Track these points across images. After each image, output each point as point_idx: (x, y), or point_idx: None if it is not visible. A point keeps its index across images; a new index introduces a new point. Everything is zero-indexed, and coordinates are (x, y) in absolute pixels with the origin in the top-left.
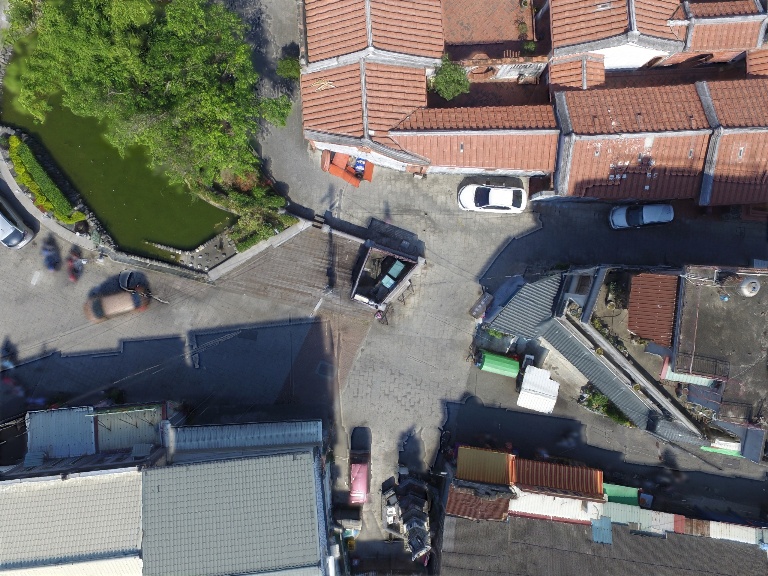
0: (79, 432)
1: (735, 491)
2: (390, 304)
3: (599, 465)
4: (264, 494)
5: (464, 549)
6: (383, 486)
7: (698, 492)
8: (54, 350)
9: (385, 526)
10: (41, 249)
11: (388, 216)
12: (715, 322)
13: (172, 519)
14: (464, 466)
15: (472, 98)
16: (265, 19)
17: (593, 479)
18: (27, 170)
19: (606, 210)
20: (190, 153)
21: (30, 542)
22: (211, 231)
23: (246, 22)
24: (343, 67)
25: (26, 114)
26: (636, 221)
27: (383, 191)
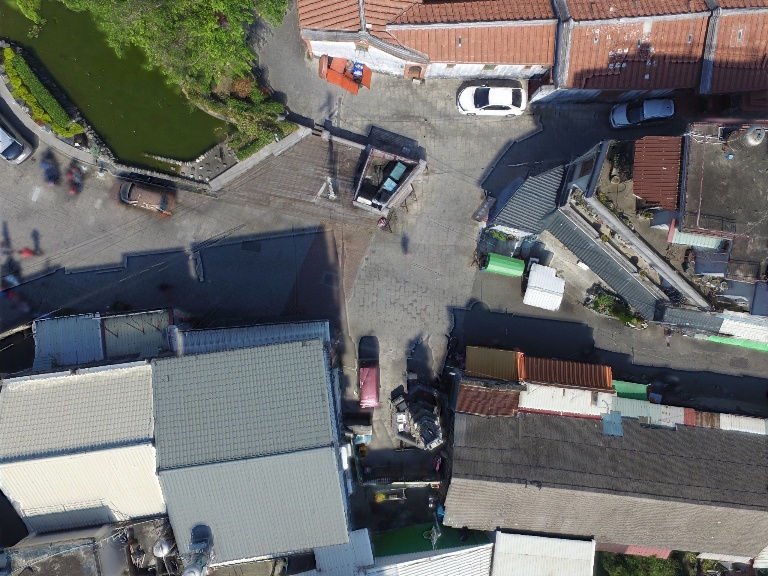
0: (86, 339)
1: (743, 390)
2: (393, 211)
3: None
4: (274, 380)
5: (475, 443)
6: (392, 395)
7: (706, 391)
8: (58, 267)
9: (395, 433)
10: (41, 165)
11: (388, 123)
12: (720, 180)
13: (183, 407)
14: (473, 364)
15: (468, 1)
16: None
17: (602, 374)
18: (23, 83)
19: (606, 110)
20: (187, 52)
21: (42, 435)
22: (211, 142)
23: None
24: None
25: (20, 28)
26: (637, 117)
27: (382, 98)
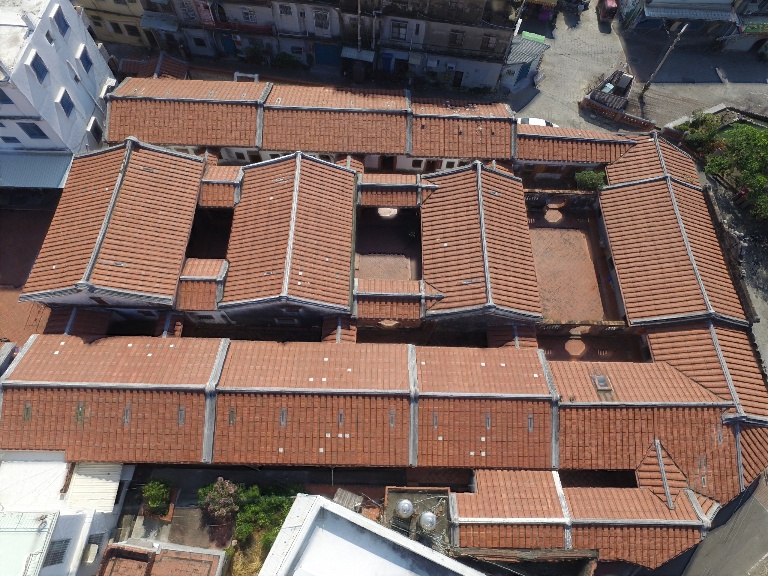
0: None
1: None
2: None
3: None
4: None
5: None
6: (588, 8)
7: None
8: None
9: None
10: None
11: None
12: None
13: None
14: None
15: None
16: None
17: None
18: None
19: None
20: None
21: None
22: None
23: None
24: None
25: None
26: None
27: None
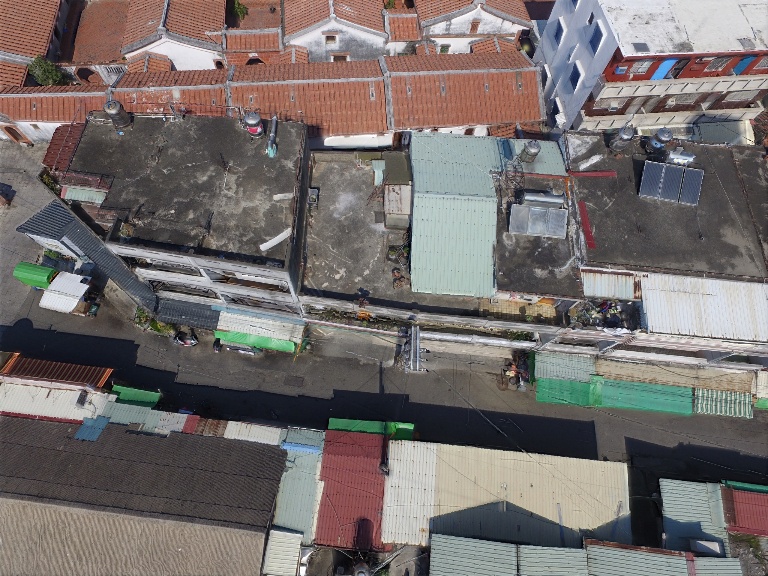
0: None
1: (298, 412)
2: None
3: (144, 385)
4: None
5: None
6: None
7: (252, 412)
8: None
9: None
10: None
11: None
12: (108, 148)
13: None
14: None
15: None
16: None
17: (99, 375)
18: None
19: None
20: None
21: None
22: None
23: None
24: None
25: None
26: None
27: None
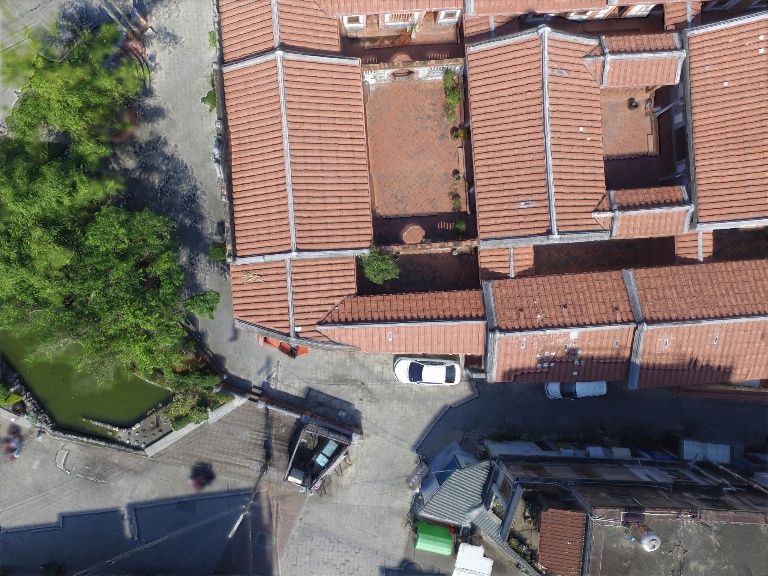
0: None
1: None
2: None
3: None
4: None
5: None
6: None
7: None
8: None
9: None
10: None
11: (325, 386)
12: (623, 562)
13: None
14: None
15: (407, 269)
16: (200, 195)
17: None
18: None
19: None
20: None
21: None
22: (148, 406)
23: (181, 199)
24: (270, 263)
25: None
26: (570, 394)
27: (320, 362)
